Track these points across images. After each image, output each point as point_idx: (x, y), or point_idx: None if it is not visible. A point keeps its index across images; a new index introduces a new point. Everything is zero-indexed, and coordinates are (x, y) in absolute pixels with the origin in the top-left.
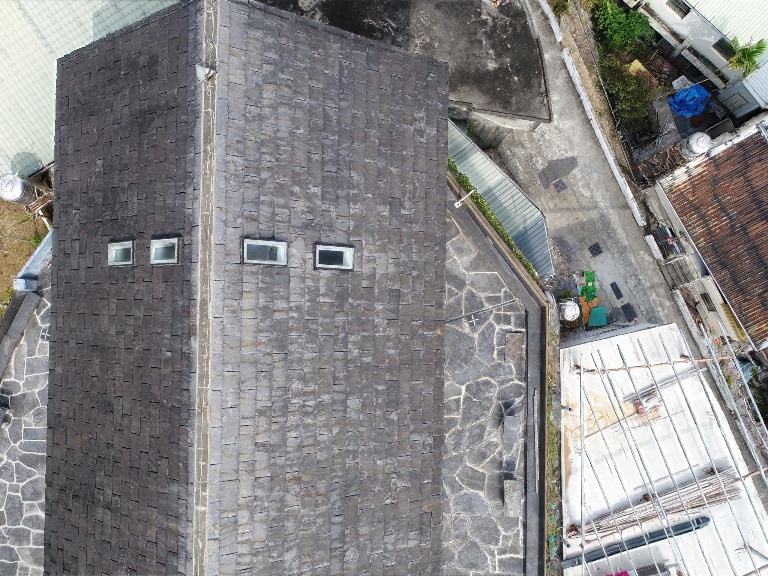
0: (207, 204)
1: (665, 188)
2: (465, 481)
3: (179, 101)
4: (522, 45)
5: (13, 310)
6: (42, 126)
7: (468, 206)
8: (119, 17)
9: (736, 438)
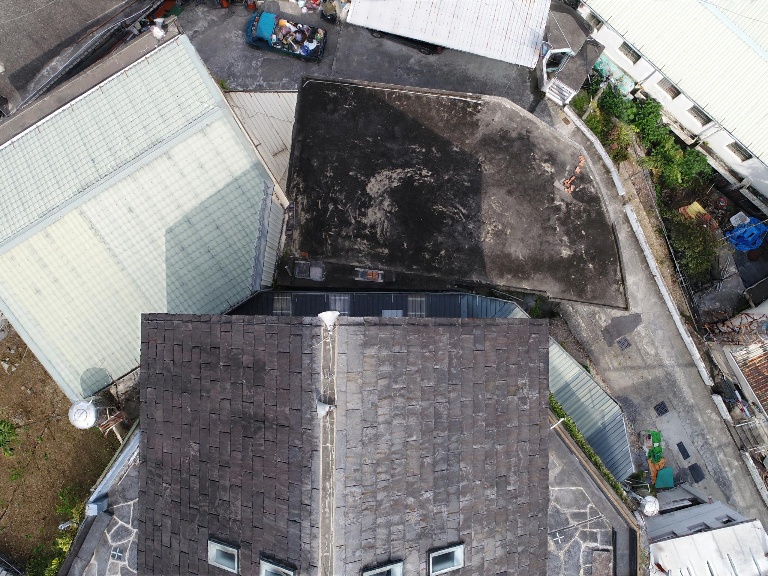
0: (327, 545)
1: (739, 362)
2: None
3: (292, 423)
4: (597, 231)
5: (84, 533)
6: (112, 341)
7: None
8: (192, 232)
9: None
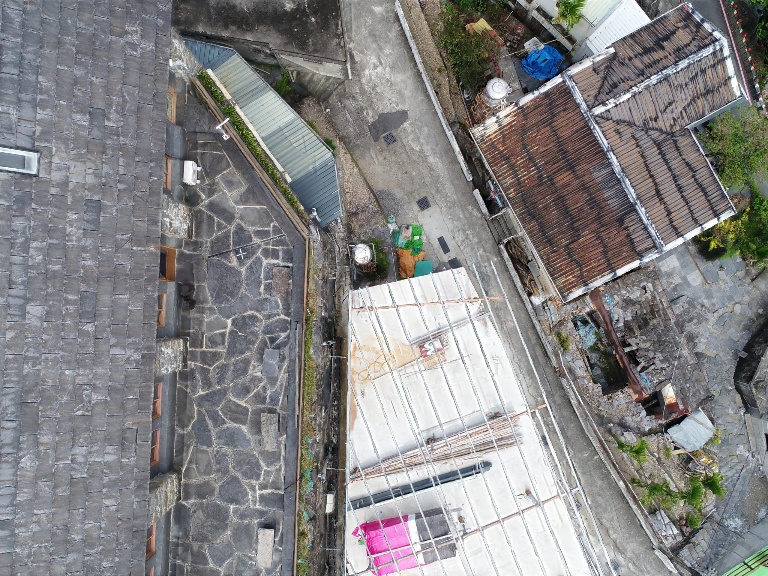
0: None
1: (477, 138)
2: (228, 415)
3: None
4: None
5: None
6: None
7: (232, 137)
8: None
9: (561, 395)
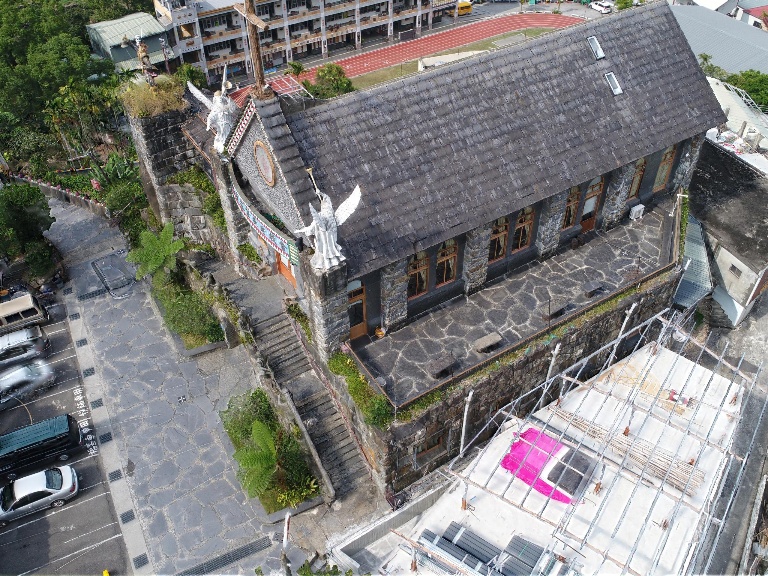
0: None
1: None
2: (537, 292)
3: None
4: None
5: None
6: None
7: None
8: None
9: None
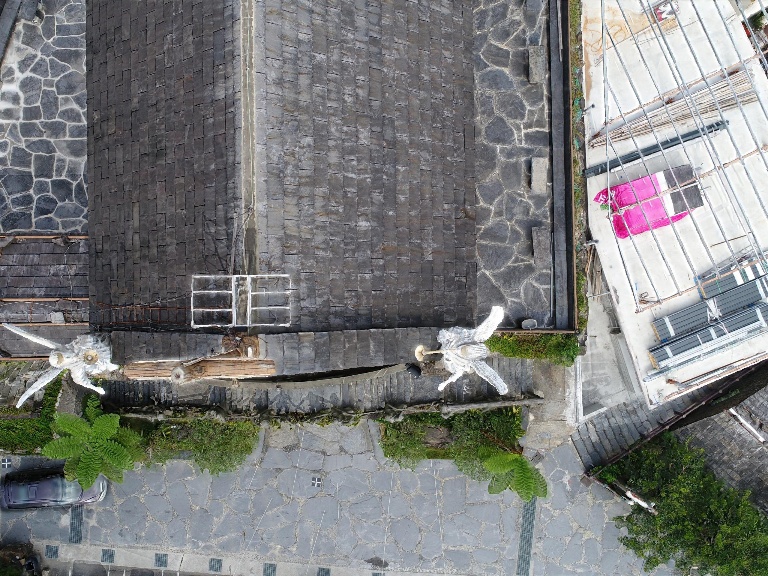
0: None
1: None
2: (490, 59)
3: None
4: None
5: None
6: None
7: None
8: None
9: None
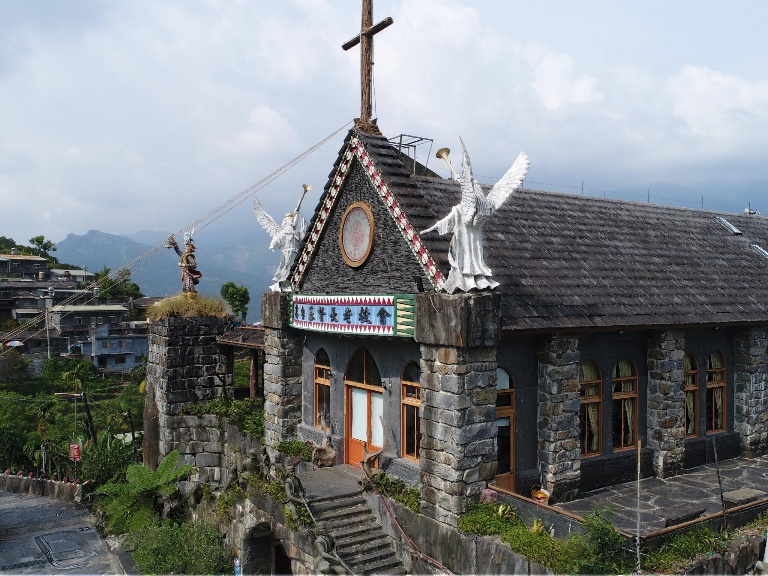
0: None
1: None
2: None
3: None
4: None
5: None
6: None
7: None
8: None
9: None
